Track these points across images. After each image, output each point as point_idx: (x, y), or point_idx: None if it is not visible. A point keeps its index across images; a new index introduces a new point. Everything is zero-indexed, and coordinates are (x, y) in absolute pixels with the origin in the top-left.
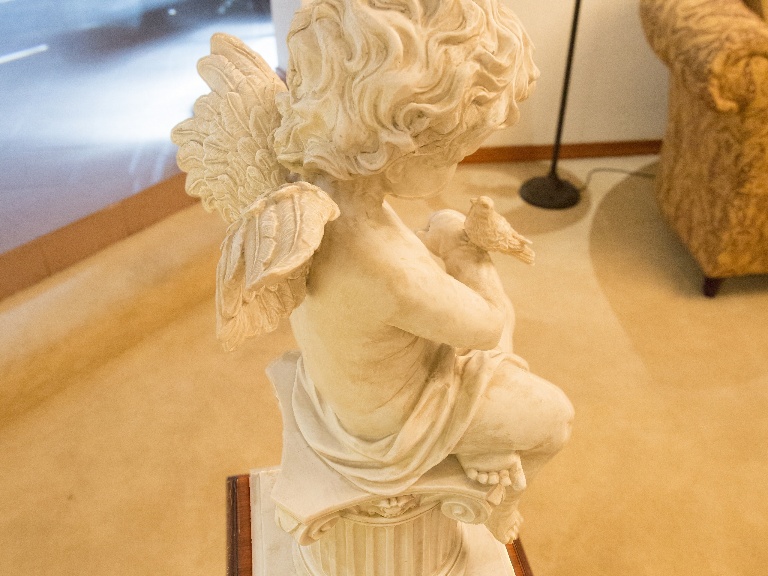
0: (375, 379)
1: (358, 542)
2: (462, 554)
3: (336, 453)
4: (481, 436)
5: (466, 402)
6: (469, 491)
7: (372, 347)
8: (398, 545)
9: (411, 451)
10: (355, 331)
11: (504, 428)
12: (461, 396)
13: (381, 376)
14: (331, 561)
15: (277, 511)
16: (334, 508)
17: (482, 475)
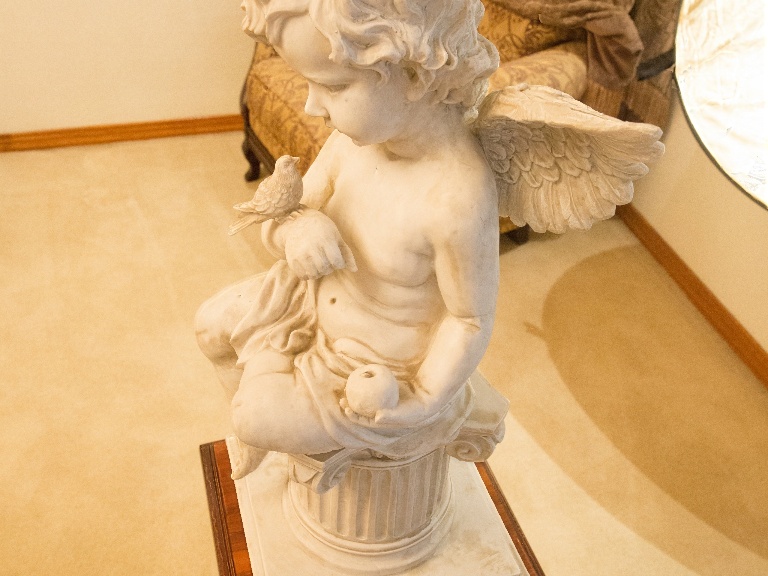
0: None
1: None
2: None
3: None
4: None
5: None
6: None
7: None
8: None
9: None
10: None
11: None
12: None
13: None
14: None
15: None
16: None
17: None
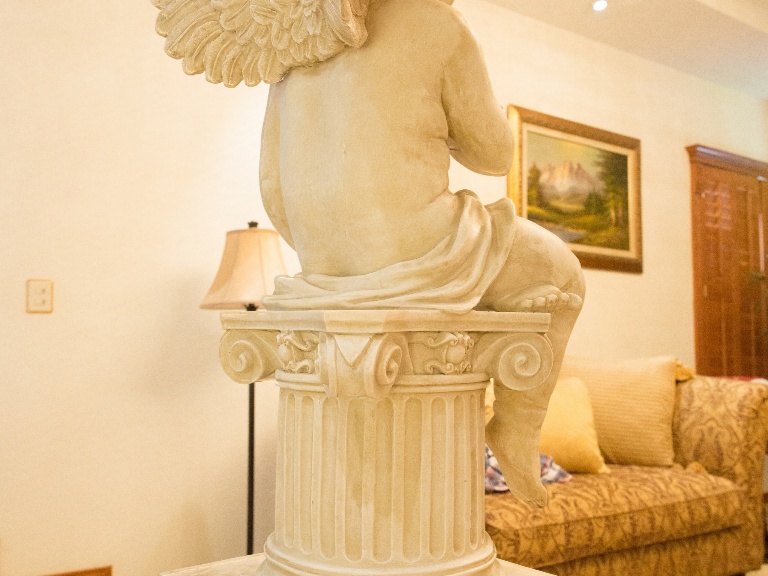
0: (427, 159)
1: (408, 445)
2: None
3: (378, 290)
4: (526, 250)
5: (504, 213)
6: (532, 315)
7: (429, 105)
8: (455, 445)
9: (467, 262)
10: (416, 77)
11: (543, 244)
12: (495, 213)
13: (432, 157)
14: (366, 511)
15: (330, 344)
16: (408, 316)
17: (538, 297)
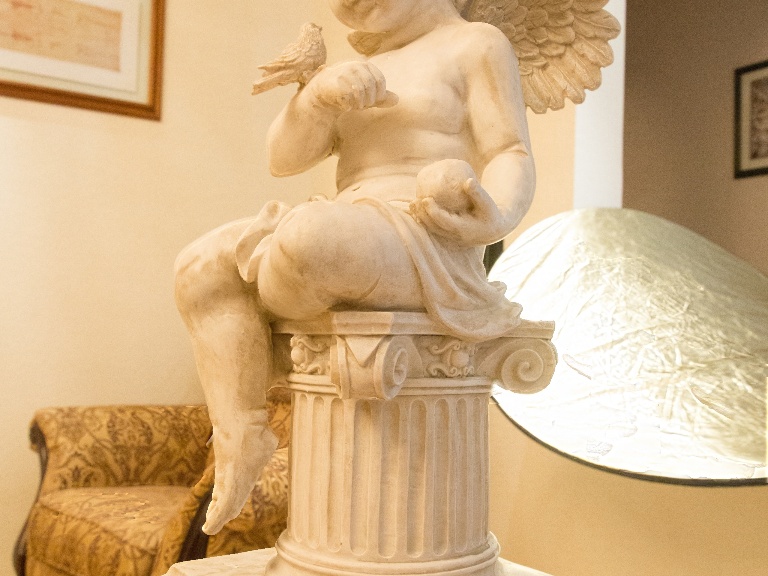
0: None
1: None
2: (275, 564)
3: None
4: None
5: None
6: None
7: None
8: None
9: None
10: None
11: None
12: None
13: None
14: None
15: None
16: None
17: None
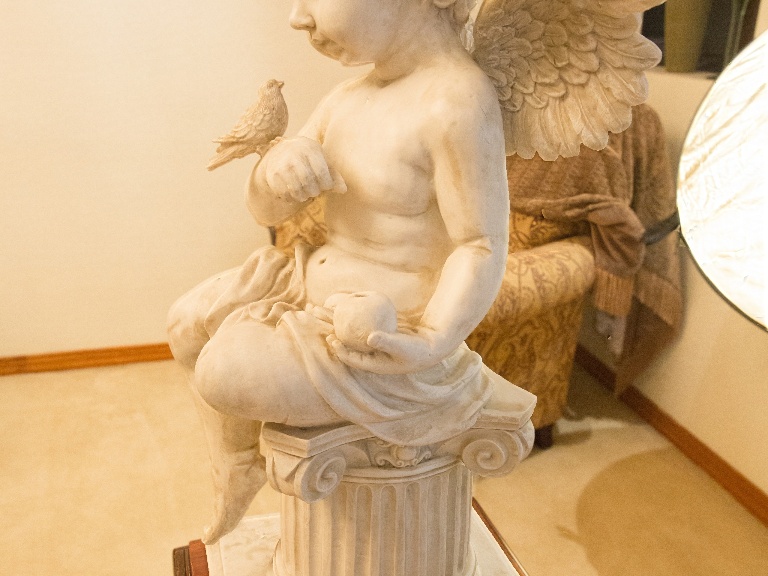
0: None
1: None
2: None
3: None
4: None
5: None
6: None
7: None
8: None
9: None
10: None
11: None
12: None
13: None
14: None
15: None
16: None
17: None
